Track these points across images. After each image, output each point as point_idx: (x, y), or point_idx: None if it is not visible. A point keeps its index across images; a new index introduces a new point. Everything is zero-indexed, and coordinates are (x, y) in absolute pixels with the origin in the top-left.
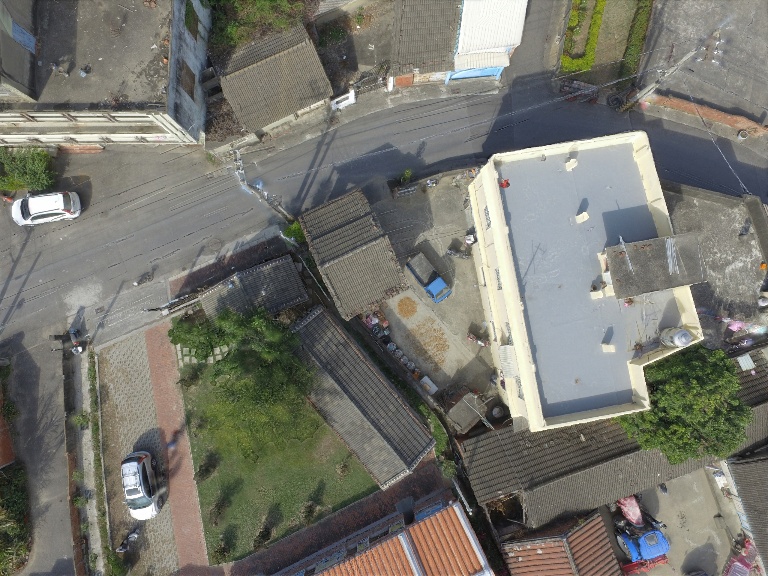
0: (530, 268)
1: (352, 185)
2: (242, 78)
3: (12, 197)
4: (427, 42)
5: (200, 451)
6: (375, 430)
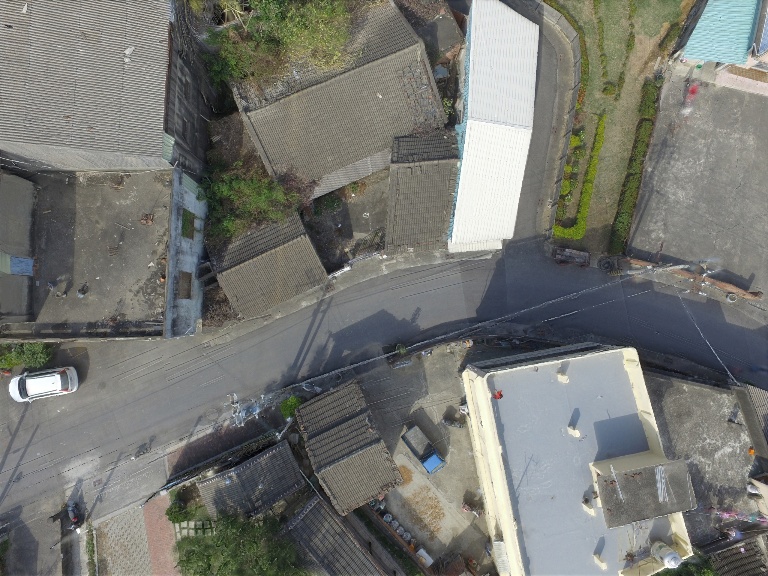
0: (523, 480)
1: (348, 352)
2: (238, 272)
3: (9, 370)
4: (421, 225)
5: None
6: None
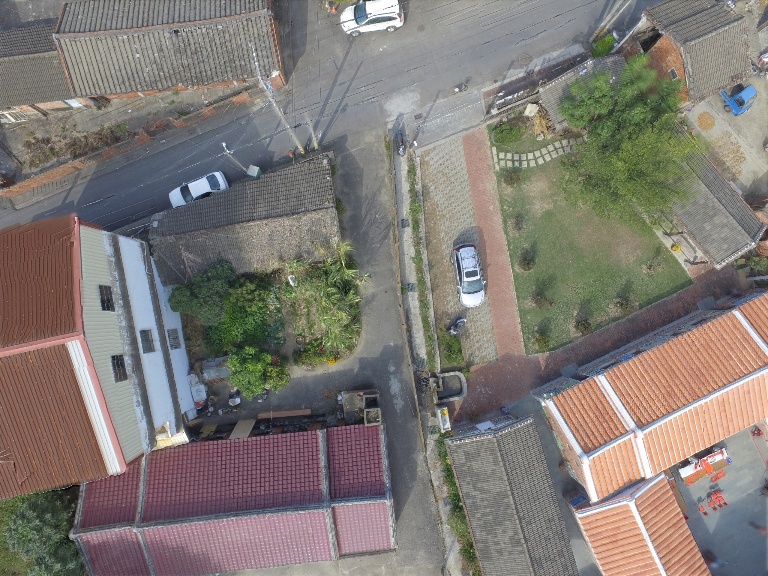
0: None
1: None
2: None
3: (336, 9)
4: None
5: (516, 248)
6: (721, 206)
